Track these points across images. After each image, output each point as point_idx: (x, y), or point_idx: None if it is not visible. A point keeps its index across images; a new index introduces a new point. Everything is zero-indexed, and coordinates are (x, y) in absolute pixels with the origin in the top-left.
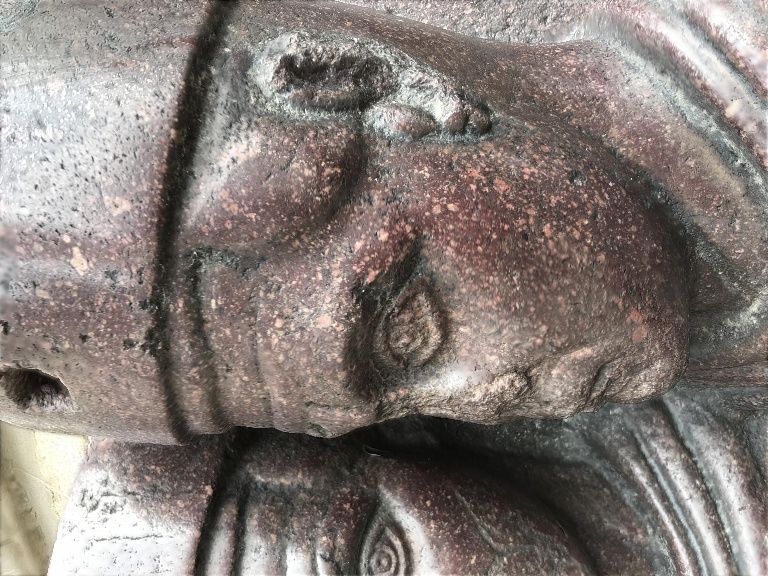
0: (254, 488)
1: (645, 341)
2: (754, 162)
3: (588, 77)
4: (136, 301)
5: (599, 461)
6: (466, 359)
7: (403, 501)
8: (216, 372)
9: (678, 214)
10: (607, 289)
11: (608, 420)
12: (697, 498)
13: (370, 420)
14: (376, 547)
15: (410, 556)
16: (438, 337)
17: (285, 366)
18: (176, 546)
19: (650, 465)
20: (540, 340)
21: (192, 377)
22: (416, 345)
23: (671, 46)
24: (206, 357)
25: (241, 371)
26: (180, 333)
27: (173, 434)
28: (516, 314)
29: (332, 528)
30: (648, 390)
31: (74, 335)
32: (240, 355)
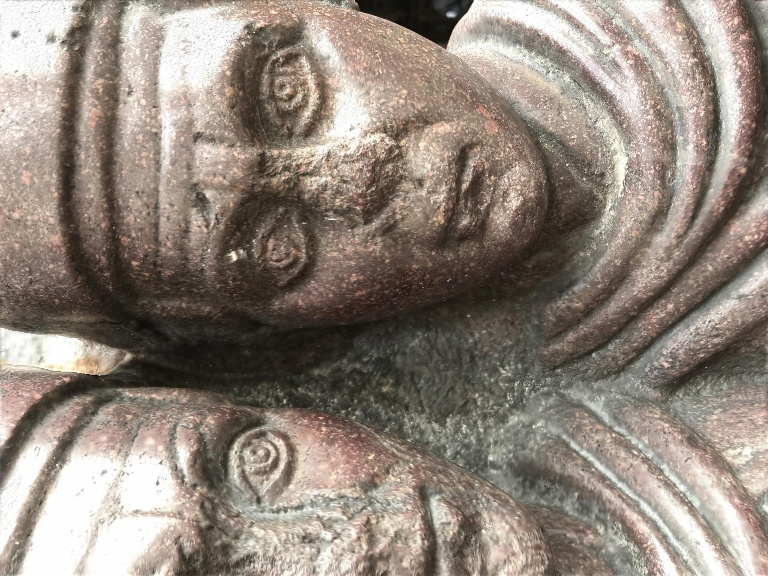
0: (118, 400)
1: (498, 135)
2: (557, 58)
3: None
4: (70, 8)
5: (533, 490)
6: (342, 125)
7: (291, 417)
8: (118, 96)
9: (518, 111)
10: (455, 83)
11: (532, 433)
12: (638, 464)
13: (252, 169)
14: (253, 442)
15: (294, 454)
16: (317, 96)
17: (181, 80)
18: (6, 402)
19: (583, 456)
20: (402, 100)
21: (96, 90)
22: (298, 101)
23: (485, 11)
24: (113, 73)
25: (141, 92)
26: (97, 45)
27: (57, 180)
28: (380, 78)
29: (202, 413)
30: (516, 200)
31: (7, 33)
32: (143, 73)
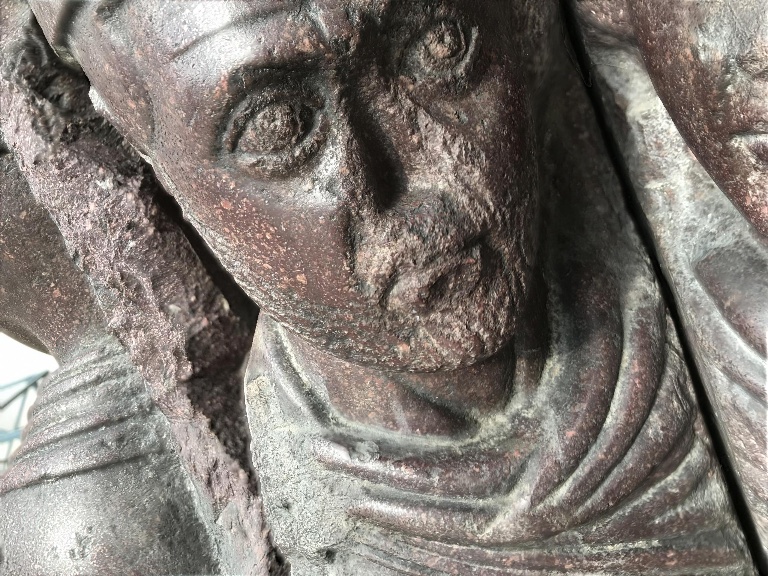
0: None
1: None
2: None
3: (50, 351)
4: None
5: None
6: None
7: None
8: None
9: None
10: None
11: None
12: None
13: None
14: None
15: None
16: None
17: None
18: None
19: None
20: None
21: None
22: None
23: None
24: None
25: None
26: None
27: None
28: None
29: None
30: None
31: None
32: None
